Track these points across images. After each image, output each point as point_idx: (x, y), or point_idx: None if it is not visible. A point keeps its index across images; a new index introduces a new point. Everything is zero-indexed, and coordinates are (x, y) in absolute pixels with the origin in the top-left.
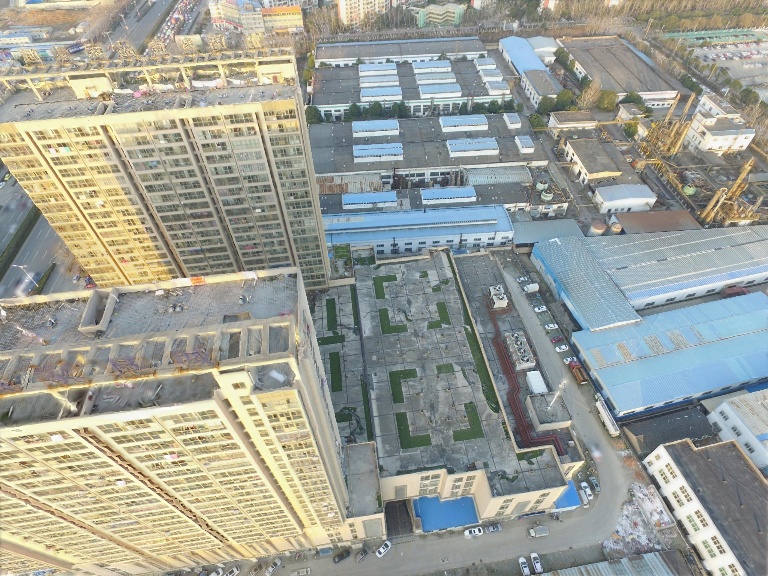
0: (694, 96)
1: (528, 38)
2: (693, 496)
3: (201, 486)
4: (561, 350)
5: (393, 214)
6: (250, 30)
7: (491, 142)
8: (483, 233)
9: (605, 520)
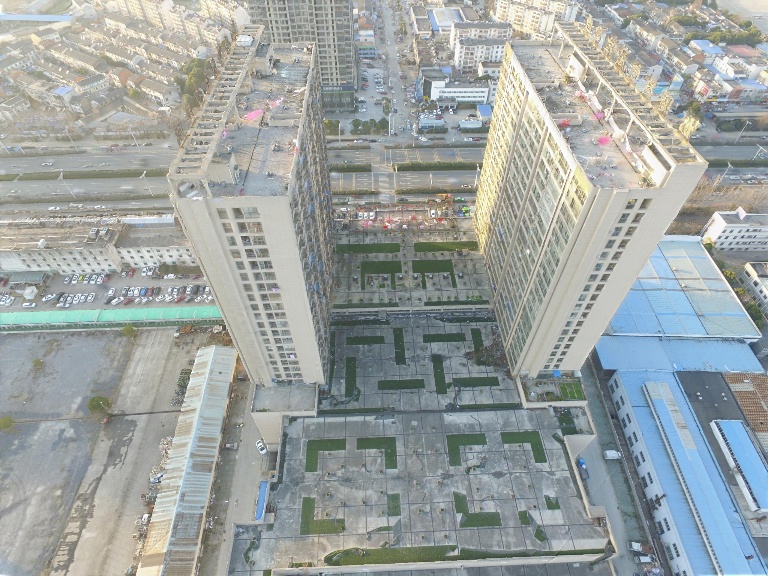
0: None
1: None
2: None
3: None
4: None
5: None
6: None
7: None
8: None
9: None
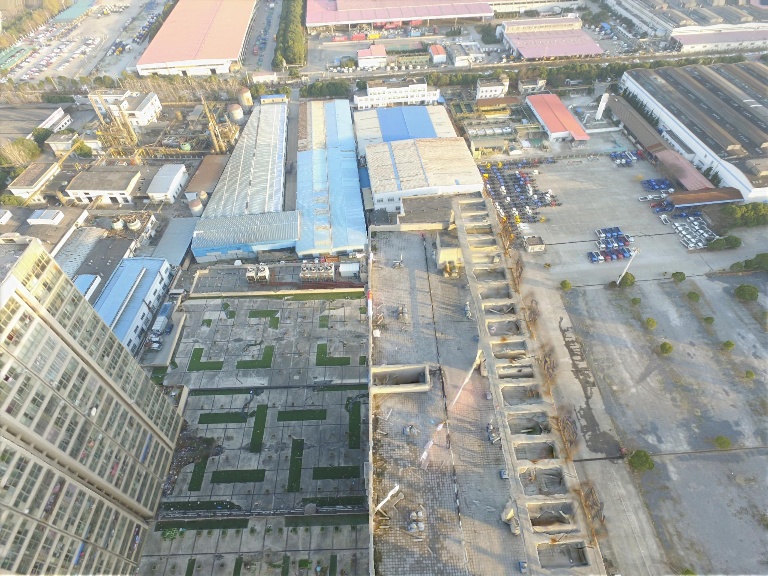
0: (99, 93)
1: None
2: None
3: None
4: None
5: None
6: None
7: None
8: (153, 283)
9: None
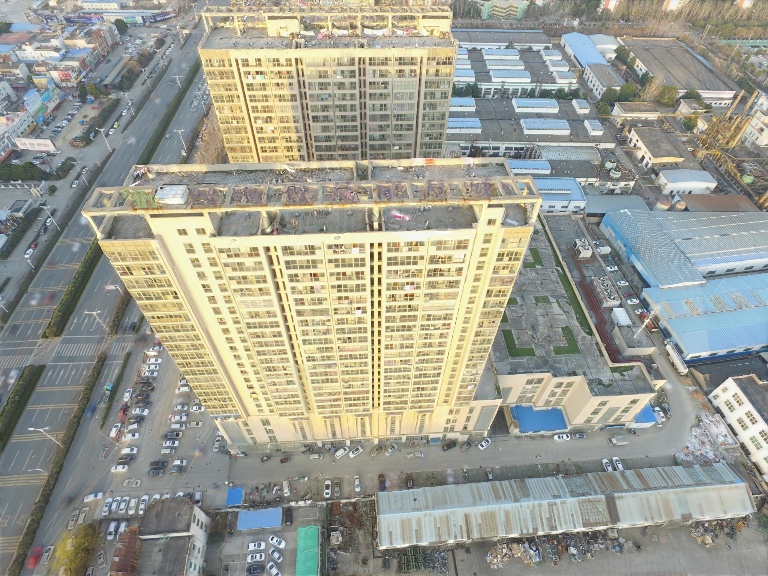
0: None
1: (590, 35)
2: (759, 418)
3: (405, 329)
4: (632, 303)
5: None
6: None
7: (563, 123)
8: (558, 201)
9: (676, 438)
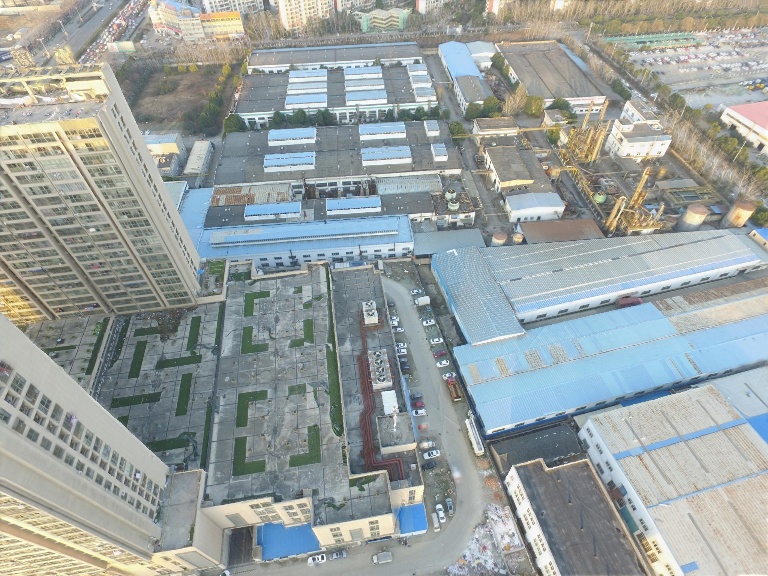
0: None
1: (467, 43)
2: (535, 520)
3: None
4: (441, 365)
5: (293, 226)
6: (190, 36)
7: (405, 150)
8: (382, 244)
9: (454, 544)
